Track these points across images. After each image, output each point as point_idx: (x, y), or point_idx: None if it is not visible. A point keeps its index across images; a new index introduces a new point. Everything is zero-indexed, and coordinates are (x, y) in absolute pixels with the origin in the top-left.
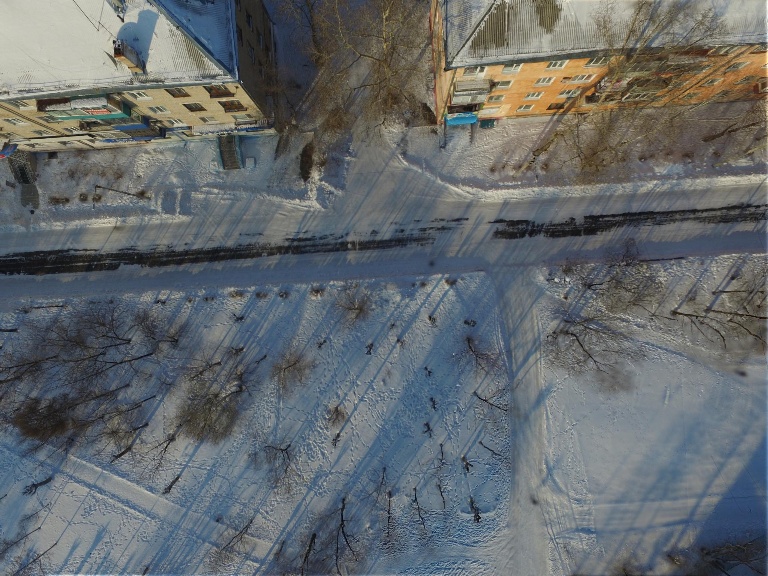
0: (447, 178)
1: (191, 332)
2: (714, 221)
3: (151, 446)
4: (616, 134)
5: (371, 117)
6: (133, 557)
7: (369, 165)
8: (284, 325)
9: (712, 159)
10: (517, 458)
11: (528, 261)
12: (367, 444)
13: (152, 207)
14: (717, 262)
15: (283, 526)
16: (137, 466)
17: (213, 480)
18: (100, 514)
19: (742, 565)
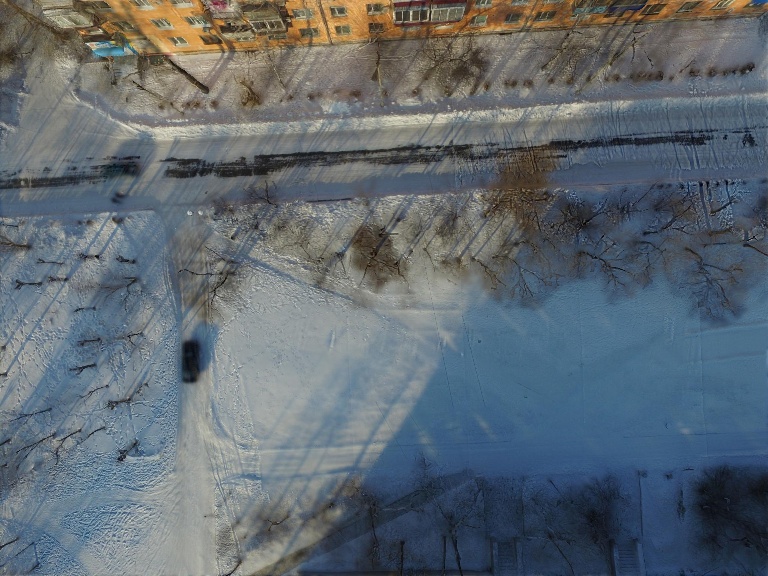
0: (119, 115)
1: None
2: (384, 162)
3: None
4: (286, 72)
5: (45, 53)
6: None
7: (43, 101)
8: None
9: None
10: (184, 401)
11: (199, 201)
12: (34, 384)
13: None
14: (383, 203)
15: None
16: None
17: None
18: None
19: (406, 515)
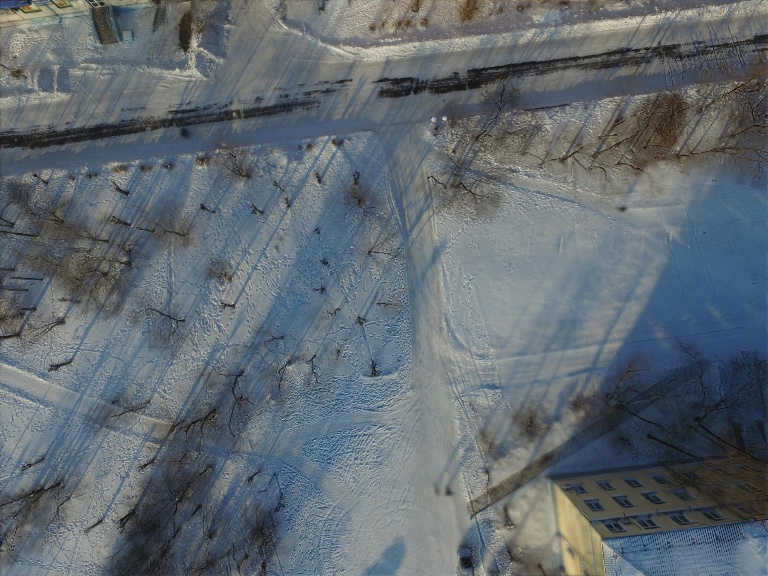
0: (328, 40)
1: (76, 211)
2: (596, 67)
3: (40, 331)
4: None
5: None
6: (27, 448)
7: (249, 32)
8: (171, 198)
9: (589, 5)
10: (417, 318)
11: (415, 119)
12: (263, 314)
13: (29, 86)
14: (600, 106)
15: (182, 404)
16: (27, 353)
17: (107, 362)
18: None
19: (648, 409)
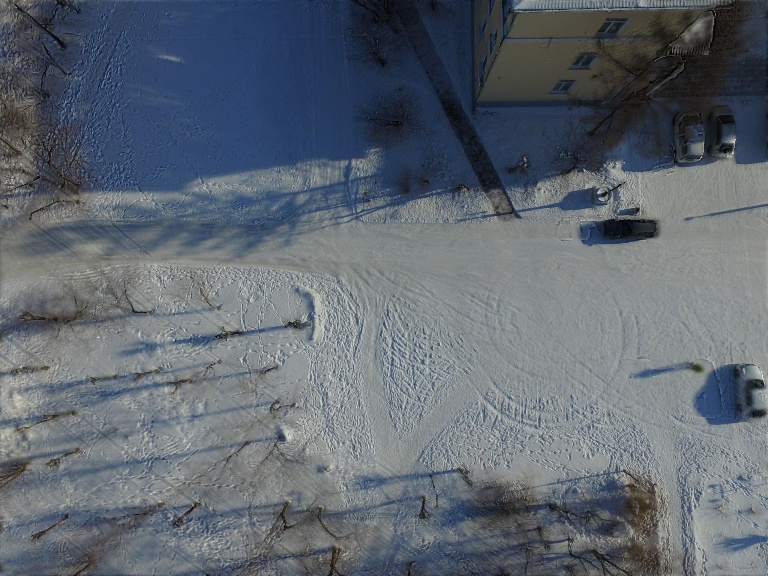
0: None
1: None
2: None
3: None
4: None
5: None
6: None
7: None
8: (40, 572)
9: None
10: (245, 259)
11: None
12: (212, 465)
13: None
14: None
15: None
16: None
17: None
18: None
19: None
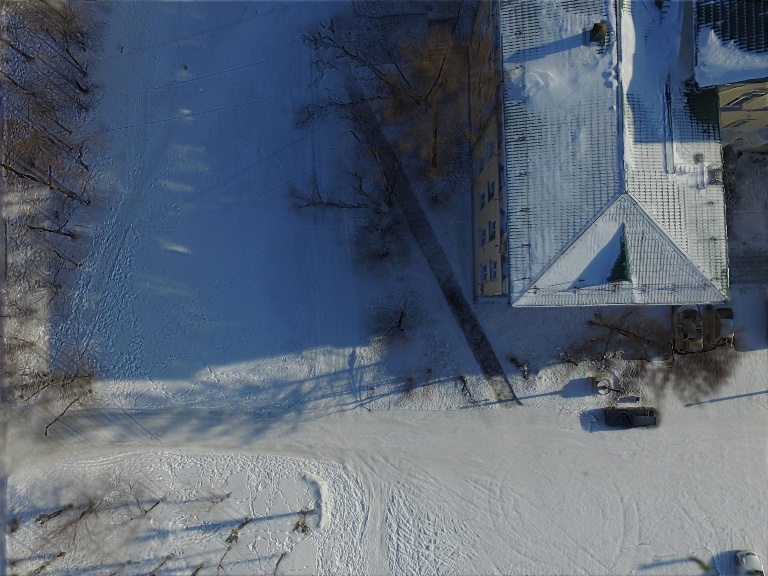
0: None
1: None
2: None
3: None
4: None
5: None
6: None
7: None
8: None
9: None
10: (253, 446)
11: (2, 418)
12: None
13: None
14: (12, 183)
15: None
16: None
17: None
18: None
19: None
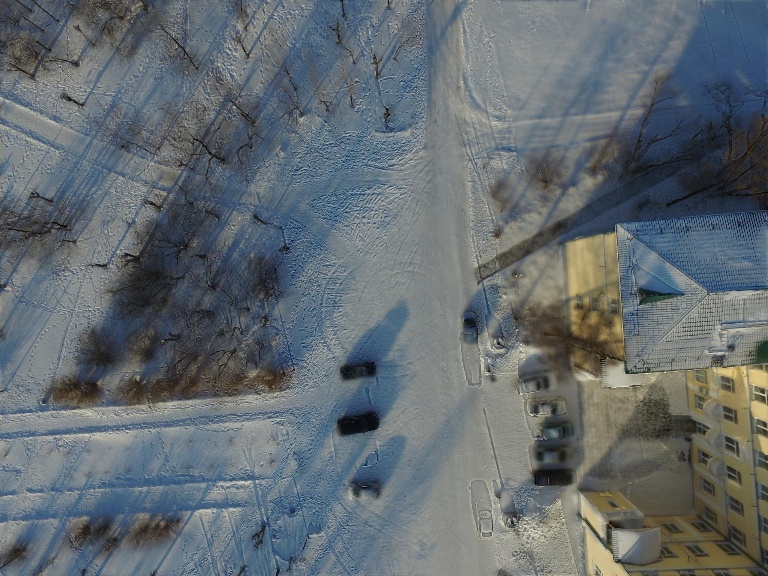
0: None
1: None
2: None
3: (54, 72)
4: None
5: None
6: (37, 189)
7: None
8: None
9: None
10: (433, 76)
11: None
12: (277, 64)
13: None
14: None
15: (191, 152)
16: (40, 95)
17: (119, 107)
18: (2, 145)
19: (669, 179)
